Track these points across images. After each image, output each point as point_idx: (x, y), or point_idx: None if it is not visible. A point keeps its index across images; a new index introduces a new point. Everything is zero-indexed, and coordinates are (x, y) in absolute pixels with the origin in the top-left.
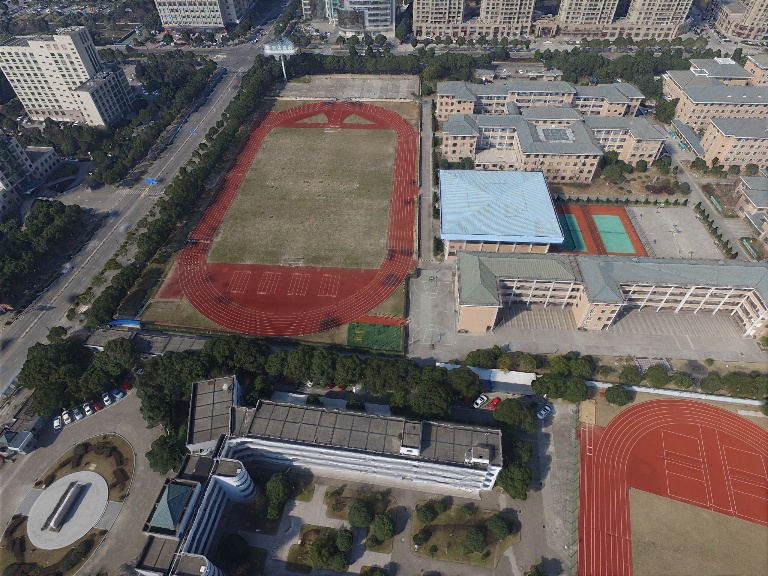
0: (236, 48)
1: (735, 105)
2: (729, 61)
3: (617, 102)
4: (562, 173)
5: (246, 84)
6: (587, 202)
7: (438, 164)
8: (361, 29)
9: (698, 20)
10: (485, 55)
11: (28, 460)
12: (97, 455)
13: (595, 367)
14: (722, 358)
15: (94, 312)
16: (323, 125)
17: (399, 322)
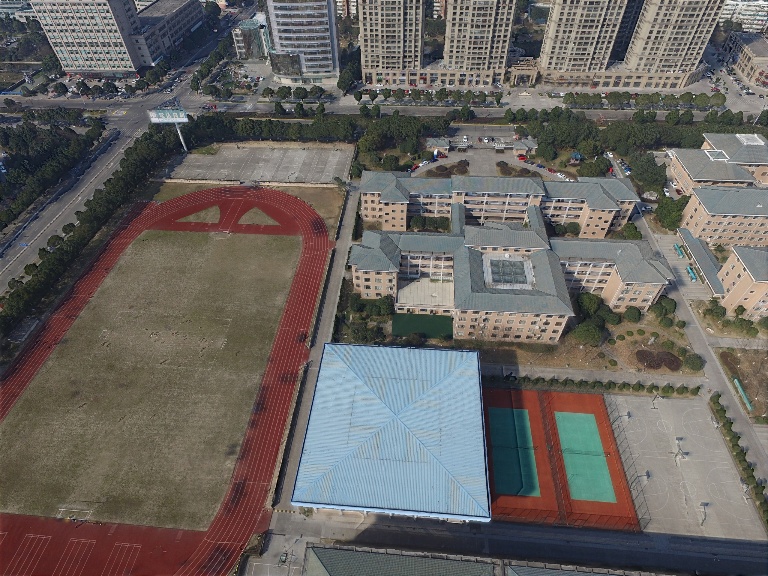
0: (143, 100)
1: (767, 217)
2: (756, 140)
3: (601, 209)
4: (516, 331)
5: (126, 161)
6: (549, 385)
7: (347, 302)
8: (298, 76)
9: (713, 62)
10: (440, 119)
11: None
12: None
13: None
14: None
15: None
16: (210, 227)
17: None
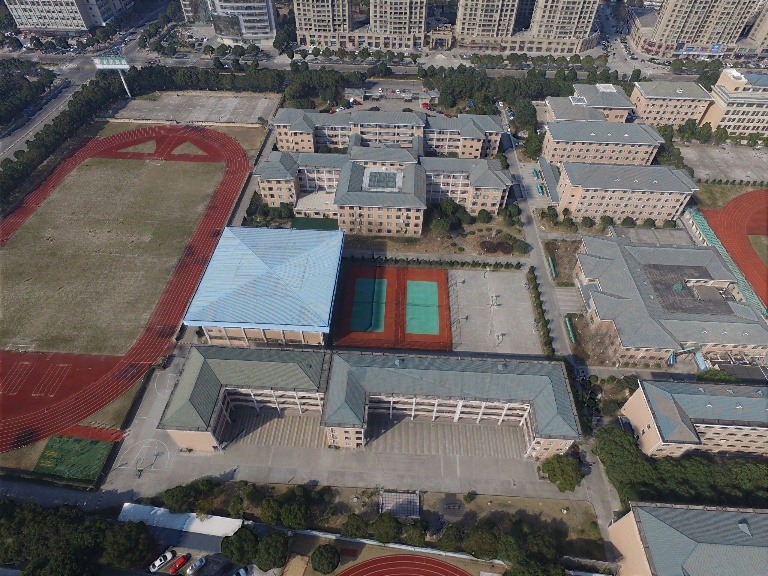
0: None
1: (600, 144)
2: (611, 88)
3: (471, 137)
4: (386, 226)
5: None
6: (407, 263)
7: (256, 209)
8: (238, 36)
9: (612, 32)
10: (357, 72)
11: None
12: None
13: (327, 505)
14: (488, 490)
15: None
16: (147, 156)
17: (113, 436)
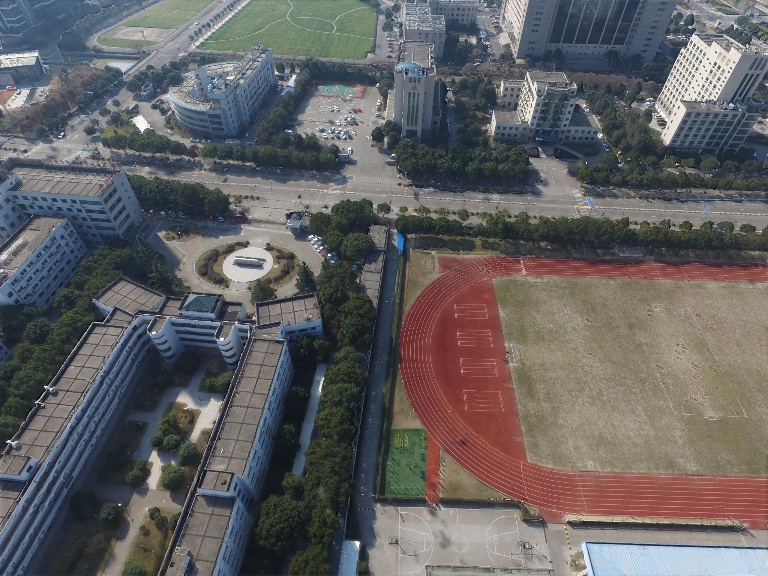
0: None
1: None
2: None
3: None
4: None
5: None
6: None
7: None
8: None
9: None
10: None
11: (286, 234)
12: (283, 265)
13: None
14: None
15: (400, 218)
16: None
17: (432, 493)
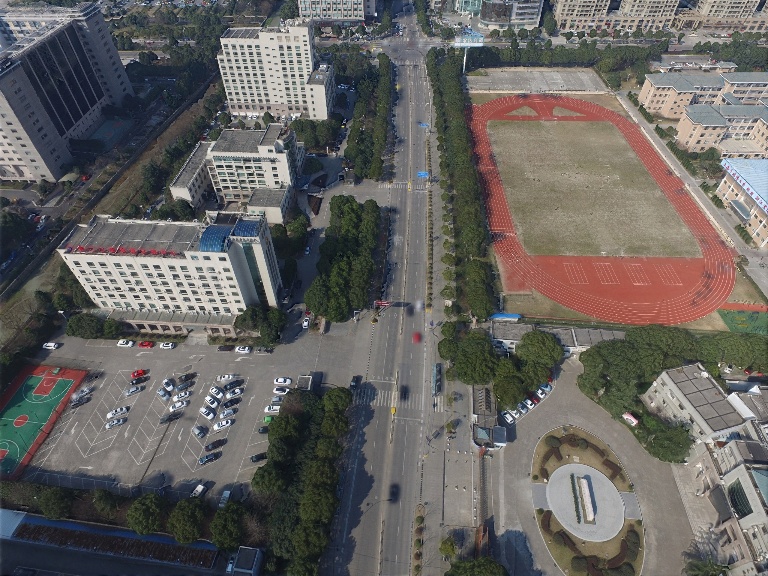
0: (386, 41)
1: None
2: None
3: None
4: None
5: (437, 77)
6: None
7: None
8: (507, 22)
9: None
10: (655, 48)
11: (505, 455)
12: (574, 447)
13: None
14: None
15: (483, 306)
16: (536, 117)
17: (764, 308)
